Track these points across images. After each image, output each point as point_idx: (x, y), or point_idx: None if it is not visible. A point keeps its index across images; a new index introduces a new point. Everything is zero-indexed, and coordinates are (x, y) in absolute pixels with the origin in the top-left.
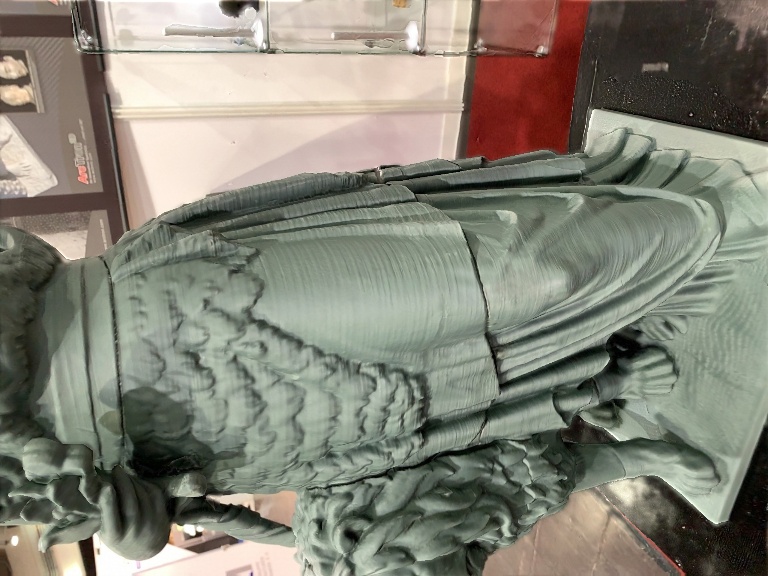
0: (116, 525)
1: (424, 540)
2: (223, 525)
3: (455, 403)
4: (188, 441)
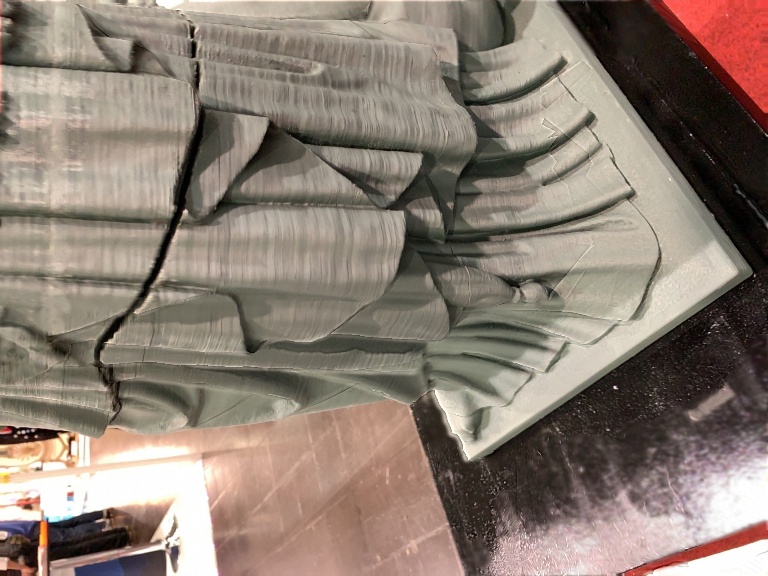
0: None
1: None
2: None
3: None
4: None
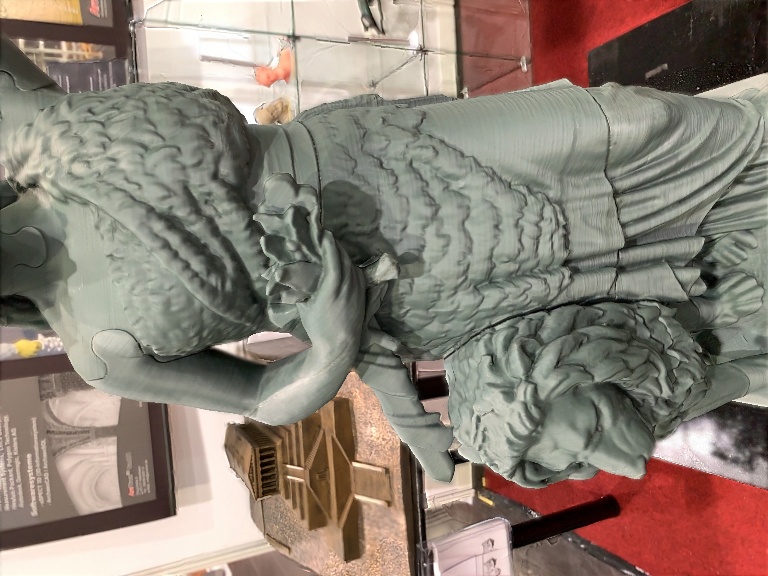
0: (338, 265)
1: (597, 356)
2: (393, 379)
3: (590, 243)
4: (376, 239)
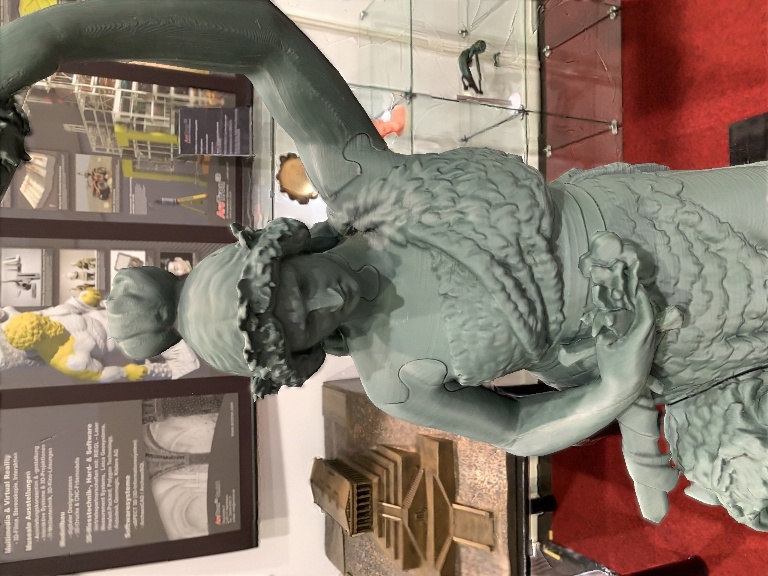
0: None
1: None
2: (647, 419)
3: None
4: (653, 292)
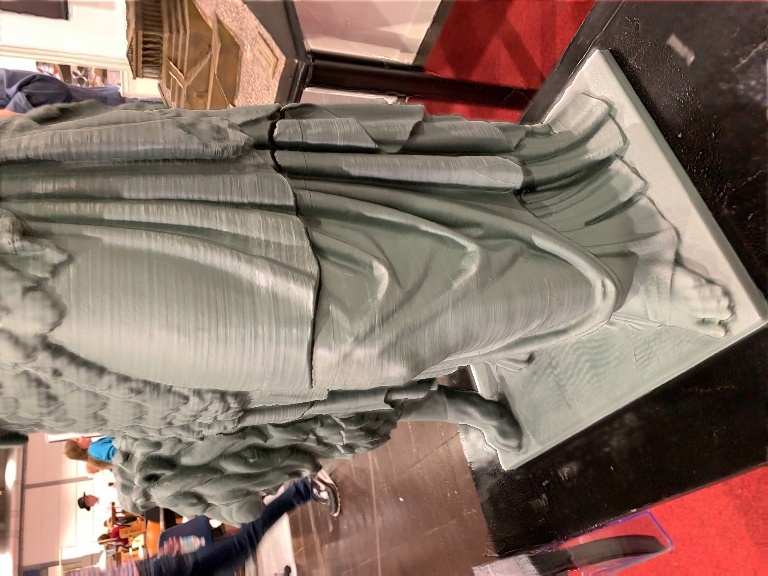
0: None
1: (218, 493)
2: None
3: (278, 402)
4: None
